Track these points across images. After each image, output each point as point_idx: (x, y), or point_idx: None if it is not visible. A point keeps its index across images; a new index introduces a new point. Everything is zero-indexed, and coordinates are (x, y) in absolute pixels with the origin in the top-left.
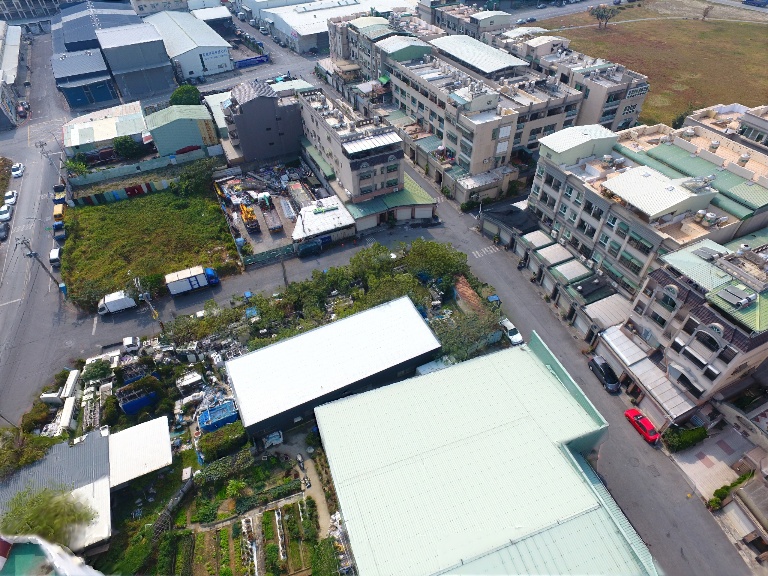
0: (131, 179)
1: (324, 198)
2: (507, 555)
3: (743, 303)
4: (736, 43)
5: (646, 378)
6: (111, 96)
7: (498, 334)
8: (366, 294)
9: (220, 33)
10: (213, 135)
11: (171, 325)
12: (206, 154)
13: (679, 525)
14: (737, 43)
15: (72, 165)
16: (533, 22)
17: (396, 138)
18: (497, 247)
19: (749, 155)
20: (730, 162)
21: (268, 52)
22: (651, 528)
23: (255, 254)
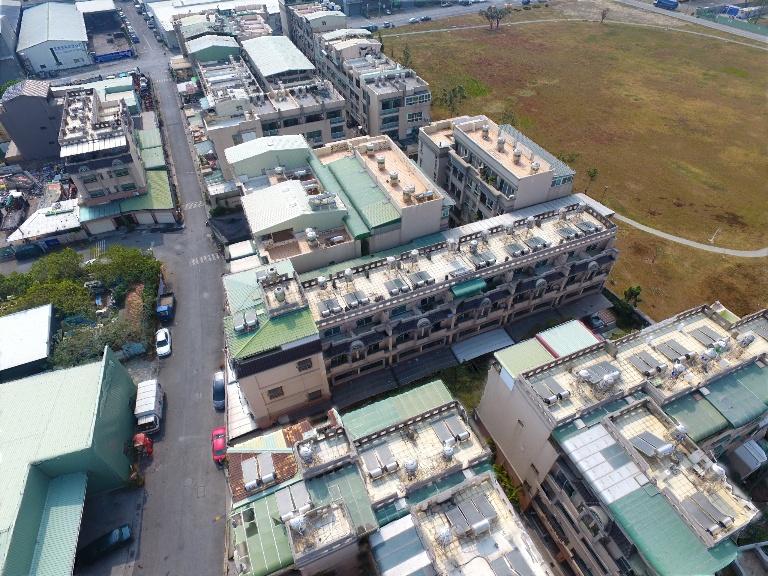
0: None
1: (69, 200)
2: None
3: (238, 329)
4: (618, 48)
5: (235, 397)
6: None
7: (138, 346)
8: None
9: (107, 26)
10: (4, 132)
11: None
12: None
13: (185, 548)
14: (619, 48)
15: None
16: (427, 21)
17: (121, 142)
18: (219, 255)
19: (414, 172)
20: (378, 179)
21: (134, 47)
22: (155, 550)
23: None
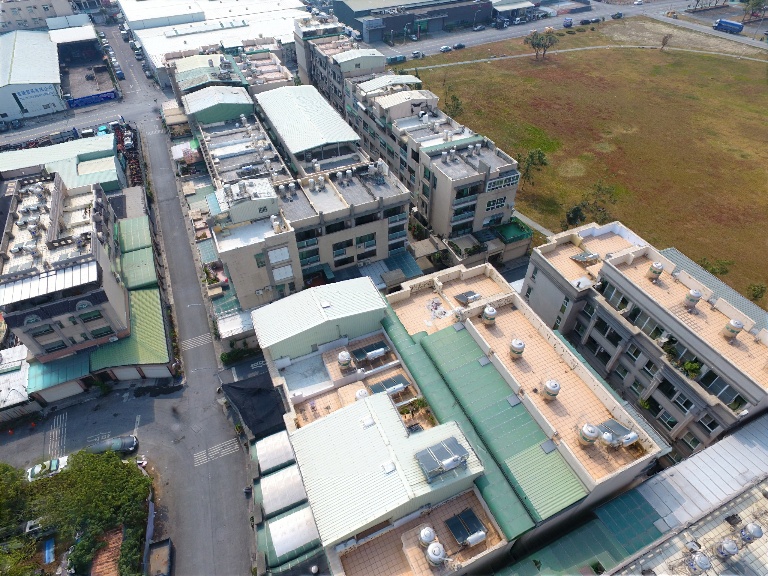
0: None
1: None
2: None
3: None
4: (693, 83)
5: None
6: None
7: None
8: None
9: (87, 57)
10: None
11: None
12: None
13: None
14: (694, 83)
15: None
16: (461, 49)
17: (89, 275)
18: (238, 443)
19: (574, 367)
20: (525, 395)
21: (118, 87)
22: None
23: None
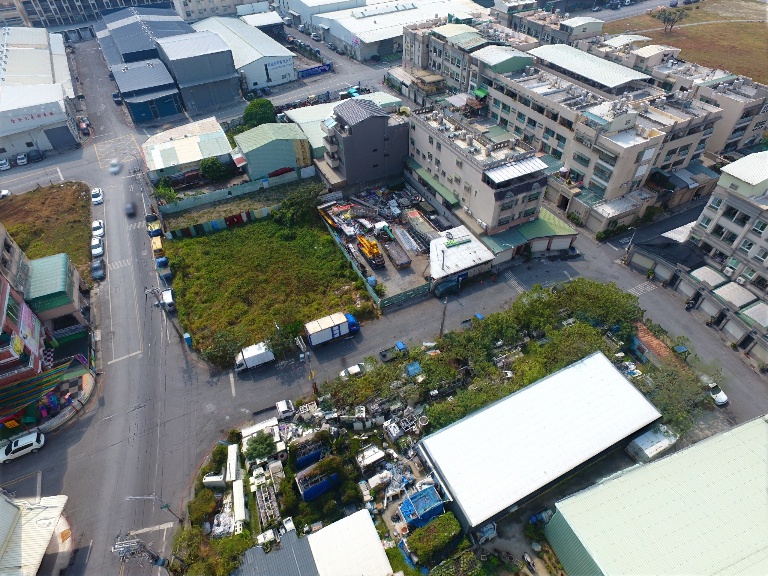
0: (223, 205)
1: None
2: None
3: None
4: None
5: None
6: (176, 110)
7: None
8: (530, 343)
9: None
10: (307, 156)
11: (328, 386)
12: (298, 176)
13: None
14: None
15: (161, 191)
16: None
17: (541, 164)
18: (653, 283)
19: None
20: None
21: (330, 60)
22: None
23: (392, 296)
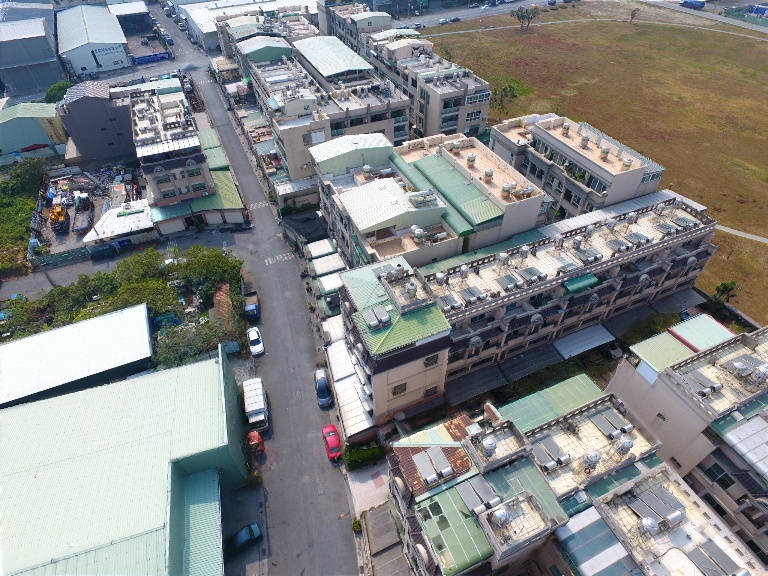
0: None
1: (137, 200)
2: (41, 574)
3: (373, 325)
4: (652, 47)
5: (344, 394)
6: None
7: (233, 344)
8: None
9: (138, 28)
10: (60, 134)
11: None
12: (55, 152)
13: (315, 545)
14: (653, 47)
15: None
16: (457, 22)
17: (194, 142)
18: (293, 254)
19: (505, 169)
20: (473, 176)
21: (171, 49)
22: (285, 548)
23: (43, 256)
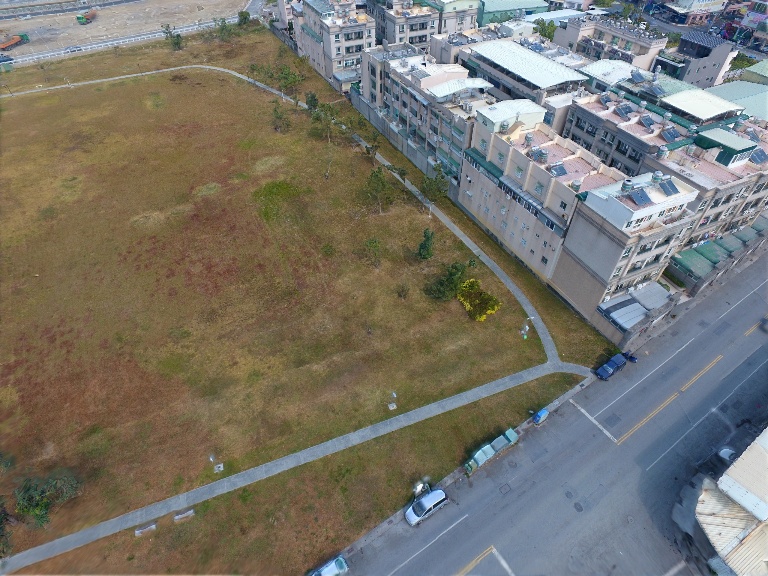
0: None
1: None
2: None
3: None
4: None
5: None
6: None
7: None
8: None
9: None
10: None
11: None
12: None
13: None
14: None
15: None
16: None
17: (564, 20)
18: None
19: None
20: None
21: None
22: None
23: None
